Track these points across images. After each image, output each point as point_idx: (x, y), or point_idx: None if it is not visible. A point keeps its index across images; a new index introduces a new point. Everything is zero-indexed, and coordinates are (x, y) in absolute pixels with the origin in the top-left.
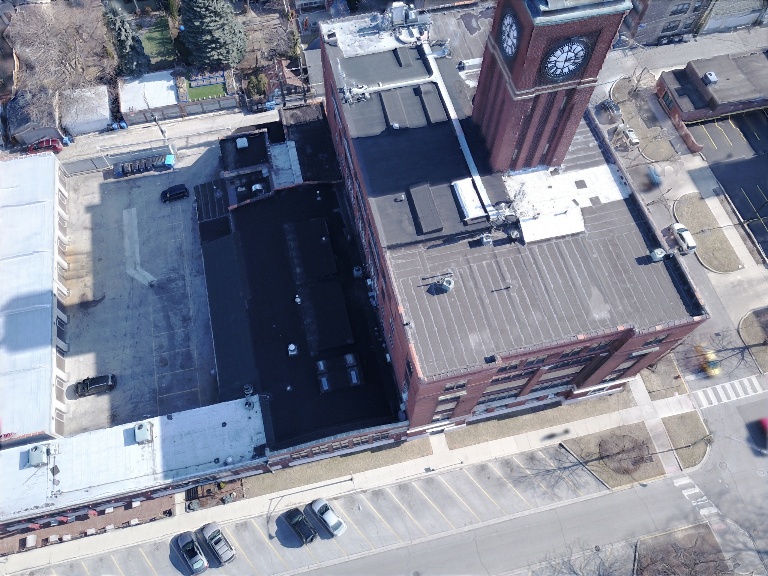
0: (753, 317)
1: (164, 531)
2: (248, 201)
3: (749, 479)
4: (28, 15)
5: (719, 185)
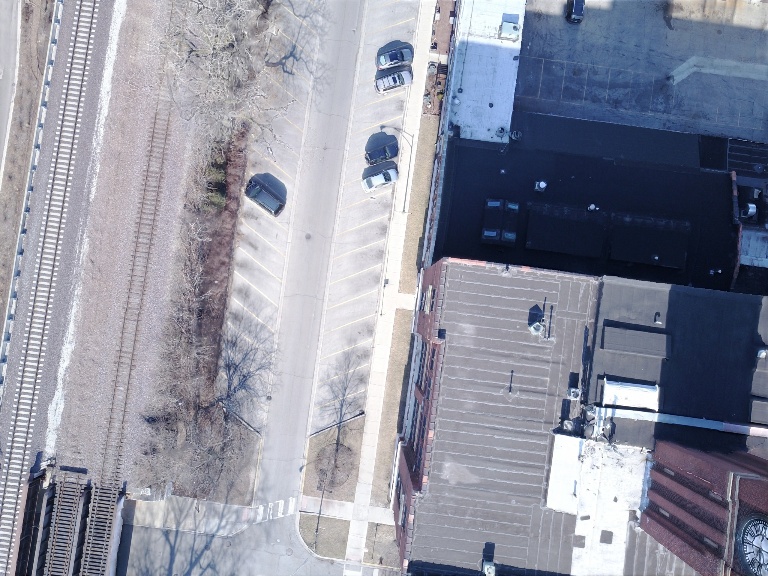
0: None
1: (421, 40)
2: (736, 193)
3: (270, 568)
4: None
5: None
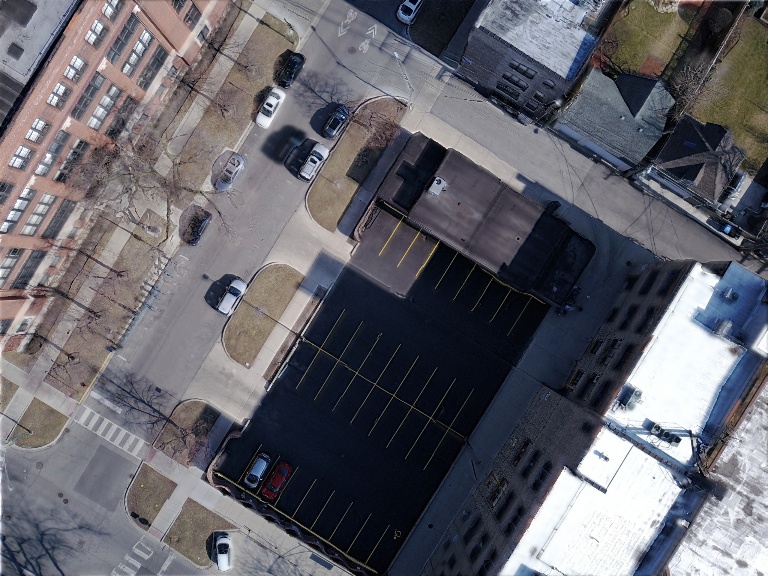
0: (201, 406)
1: None
2: None
3: (46, 490)
4: None
5: (329, 287)
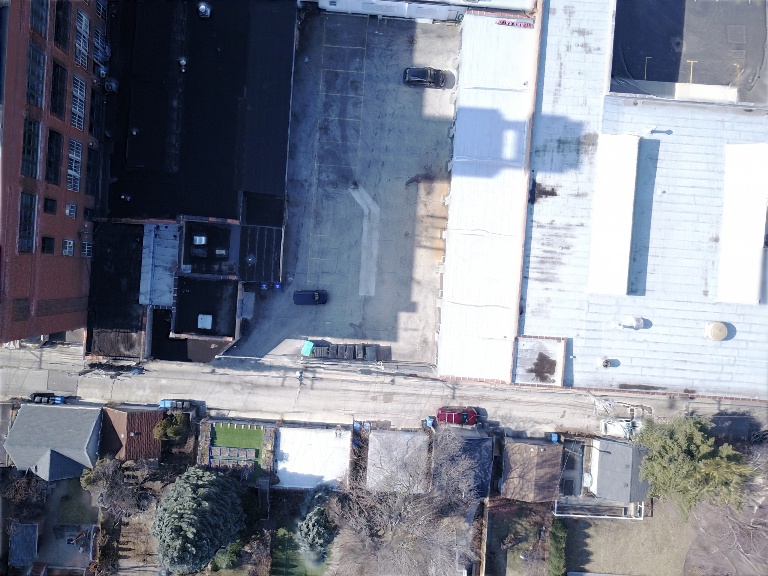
0: None
1: None
2: (212, 219)
3: None
4: (430, 571)
5: None
